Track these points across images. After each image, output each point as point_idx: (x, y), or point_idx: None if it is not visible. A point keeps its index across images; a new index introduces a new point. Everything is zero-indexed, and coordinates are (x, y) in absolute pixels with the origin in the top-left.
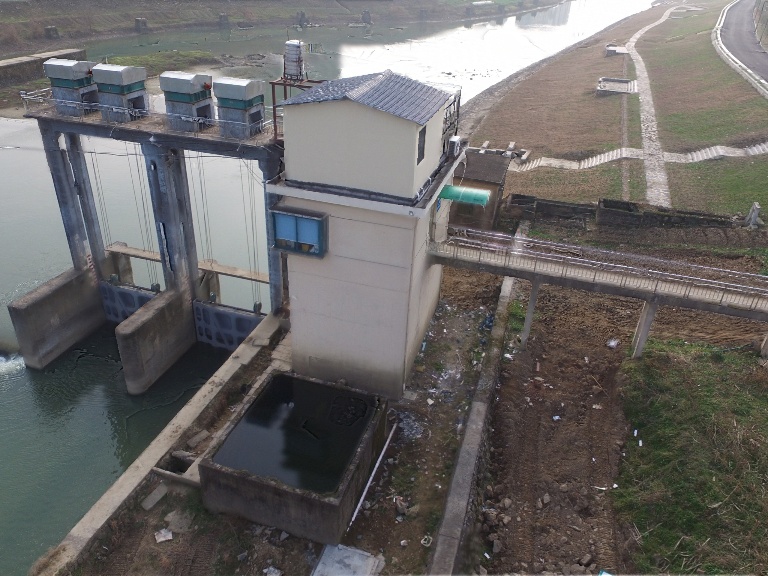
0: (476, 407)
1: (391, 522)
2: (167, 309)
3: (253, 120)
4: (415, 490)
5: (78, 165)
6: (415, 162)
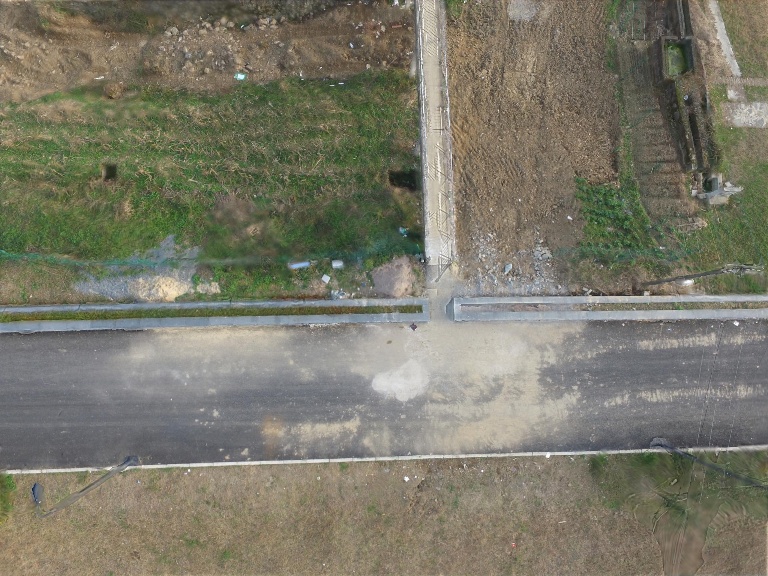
0: None
1: None
2: None
3: None
4: None
5: None
6: None
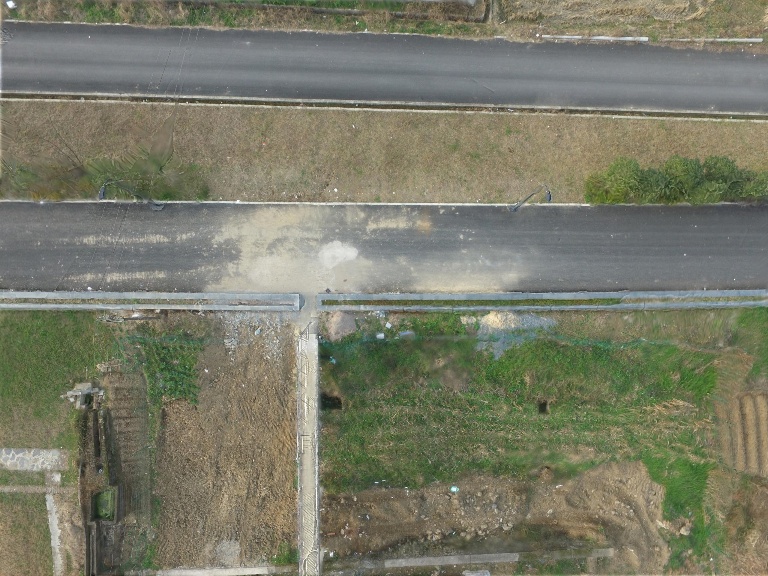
0: (390, 566)
1: (446, 575)
2: None
3: None
4: (427, 571)
5: None
6: None
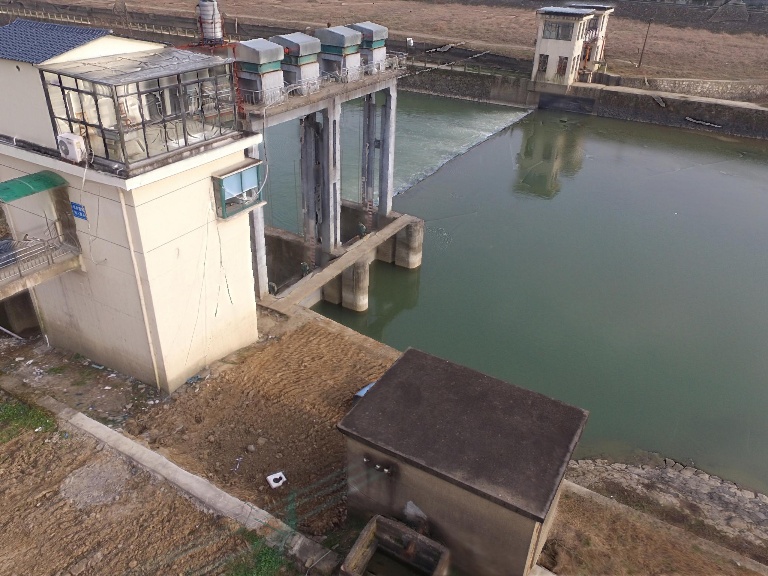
0: None
1: None
2: (286, 244)
3: (246, 86)
4: None
5: (383, 124)
6: None
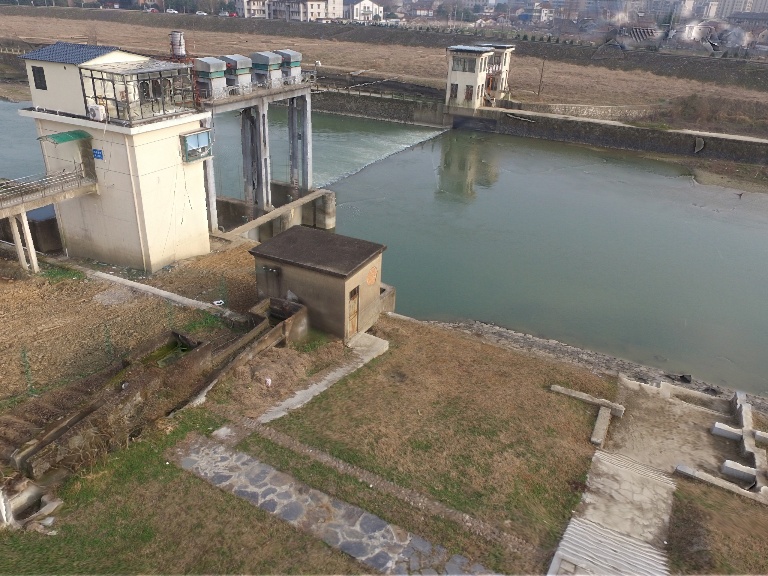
0: None
1: None
2: None
3: (201, 87)
4: None
5: (302, 121)
6: (31, 83)
